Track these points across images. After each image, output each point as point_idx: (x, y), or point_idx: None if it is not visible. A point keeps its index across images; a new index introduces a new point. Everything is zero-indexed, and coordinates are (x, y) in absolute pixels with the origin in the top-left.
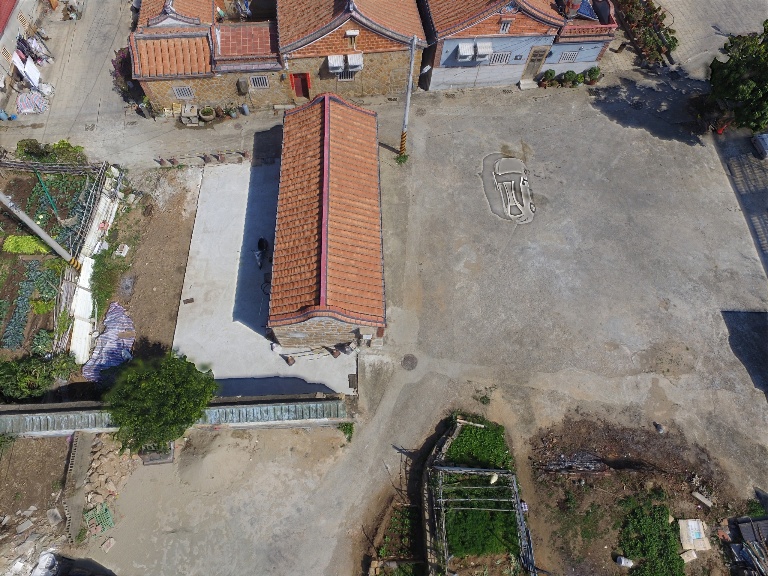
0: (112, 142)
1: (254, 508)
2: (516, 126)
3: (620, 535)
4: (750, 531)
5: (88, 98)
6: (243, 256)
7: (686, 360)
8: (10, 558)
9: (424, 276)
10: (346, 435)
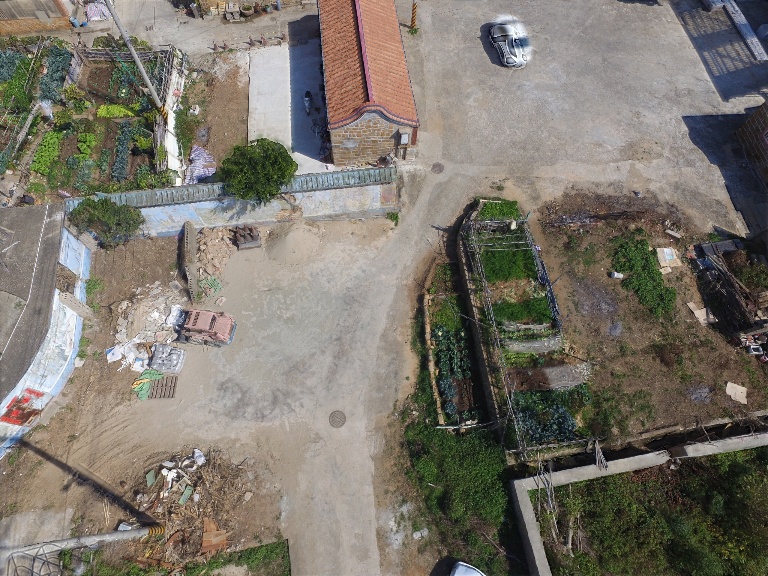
0: (170, 37)
1: (329, 272)
2: (505, 2)
3: (612, 261)
4: (710, 249)
5: (144, 7)
6: (293, 109)
7: (656, 150)
8: (150, 308)
9: (442, 110)
10: (393, 222)
